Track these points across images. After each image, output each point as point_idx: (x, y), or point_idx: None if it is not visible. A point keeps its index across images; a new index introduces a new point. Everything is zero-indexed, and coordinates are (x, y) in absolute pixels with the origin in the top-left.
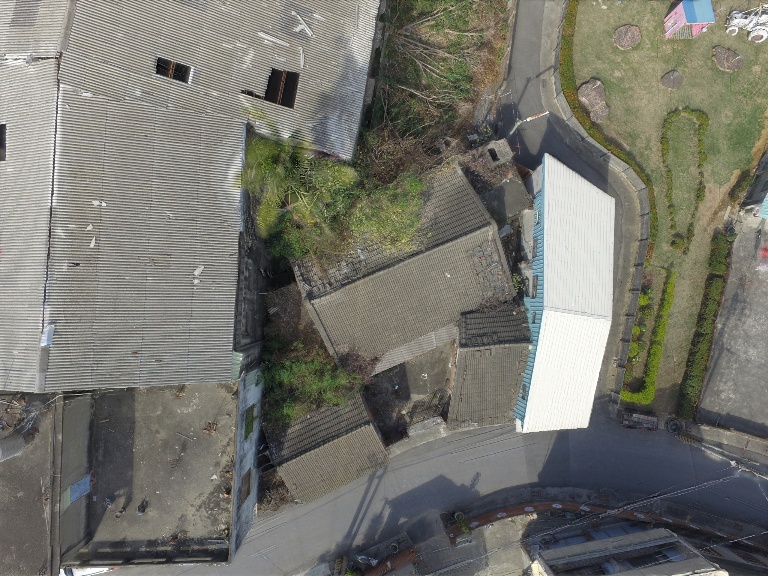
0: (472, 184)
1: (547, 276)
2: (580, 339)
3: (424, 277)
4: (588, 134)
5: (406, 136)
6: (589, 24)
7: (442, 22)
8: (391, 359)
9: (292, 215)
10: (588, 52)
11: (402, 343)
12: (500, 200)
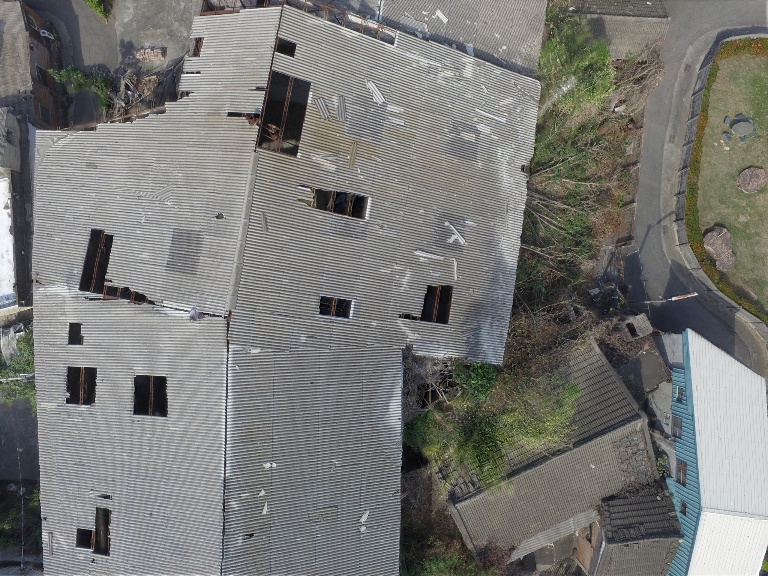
0: (607, 357)
1: (702, 472)
2: (740, 539)
3: (568, 470)
4: (717, 288)
5: (539, 311)
6: (711, 166)
7: (559, 171)
8: (528, 546)
9: (434, 415)
10: (711, 196)
11: (540, 531)
12: (636, 373)
